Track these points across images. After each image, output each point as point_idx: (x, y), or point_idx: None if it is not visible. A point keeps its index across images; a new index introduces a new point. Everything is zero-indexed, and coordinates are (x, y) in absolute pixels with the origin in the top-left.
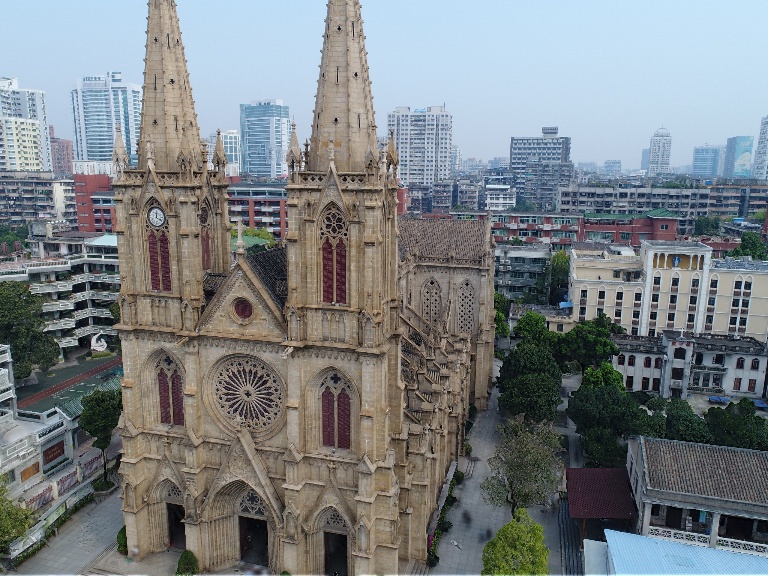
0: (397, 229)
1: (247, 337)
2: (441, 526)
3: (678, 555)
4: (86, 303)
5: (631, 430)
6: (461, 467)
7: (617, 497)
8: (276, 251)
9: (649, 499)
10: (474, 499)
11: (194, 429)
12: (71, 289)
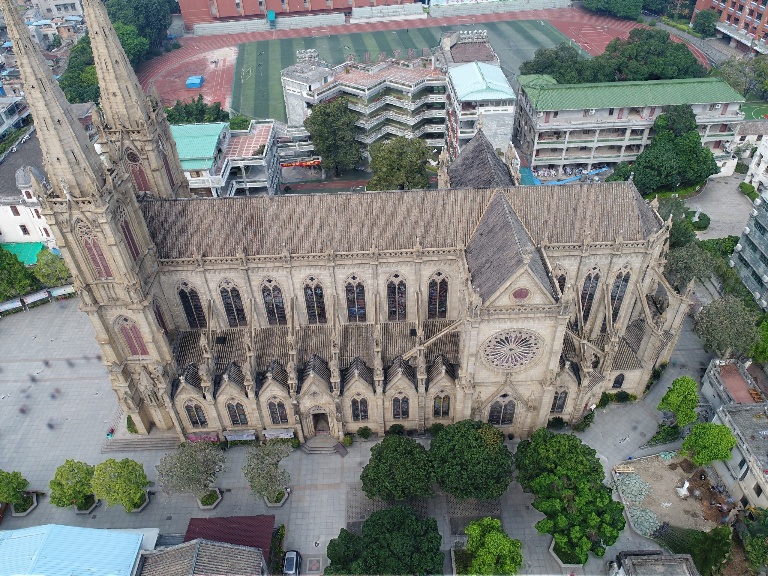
0: (112, 240)
1: None
2: (220, 444)
3: None
4: (444, 120)
5: None
6: (317, 442)
7: None
8: (156, 201)
9: None
10: None
11: None
12: (412, 109)
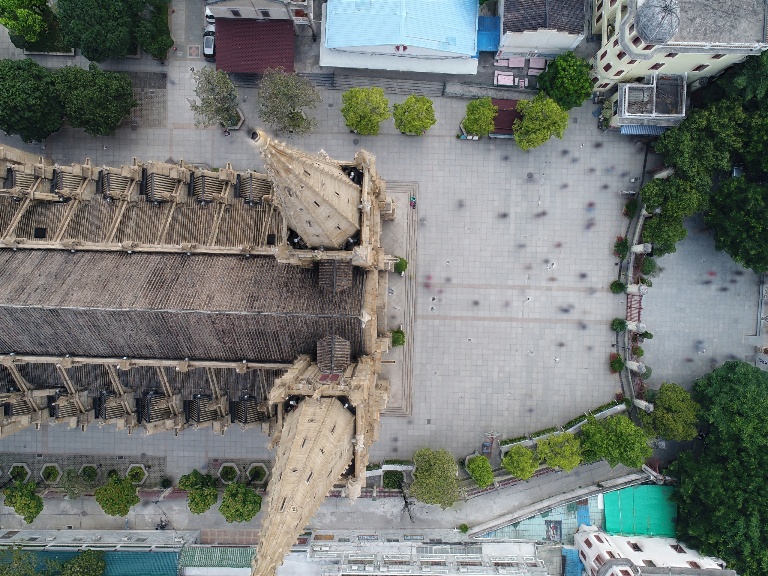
0: None
1: (374, 305)
2: None
3: (354, 2)
4: None
5: (156, 0)
6: None
7: (265, 33)
8: (290, 312)
9: (311, 7)
10: (241, 158)
11: (380, 348)
12: None
